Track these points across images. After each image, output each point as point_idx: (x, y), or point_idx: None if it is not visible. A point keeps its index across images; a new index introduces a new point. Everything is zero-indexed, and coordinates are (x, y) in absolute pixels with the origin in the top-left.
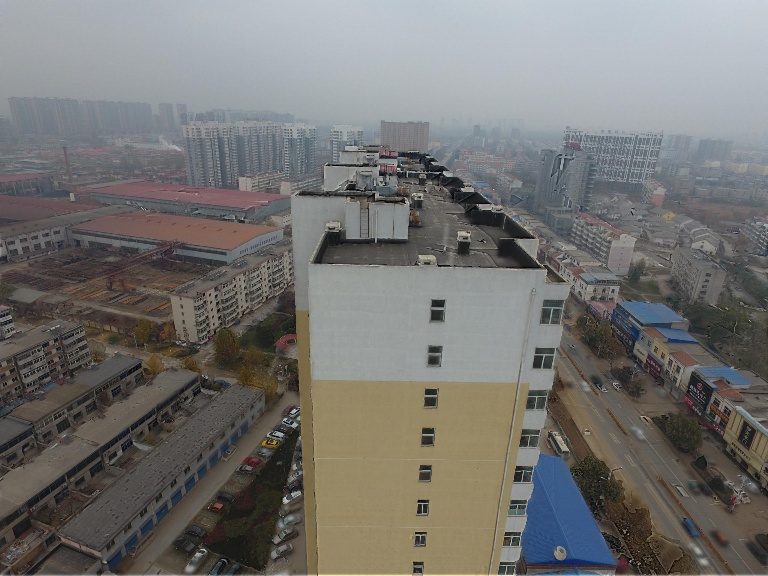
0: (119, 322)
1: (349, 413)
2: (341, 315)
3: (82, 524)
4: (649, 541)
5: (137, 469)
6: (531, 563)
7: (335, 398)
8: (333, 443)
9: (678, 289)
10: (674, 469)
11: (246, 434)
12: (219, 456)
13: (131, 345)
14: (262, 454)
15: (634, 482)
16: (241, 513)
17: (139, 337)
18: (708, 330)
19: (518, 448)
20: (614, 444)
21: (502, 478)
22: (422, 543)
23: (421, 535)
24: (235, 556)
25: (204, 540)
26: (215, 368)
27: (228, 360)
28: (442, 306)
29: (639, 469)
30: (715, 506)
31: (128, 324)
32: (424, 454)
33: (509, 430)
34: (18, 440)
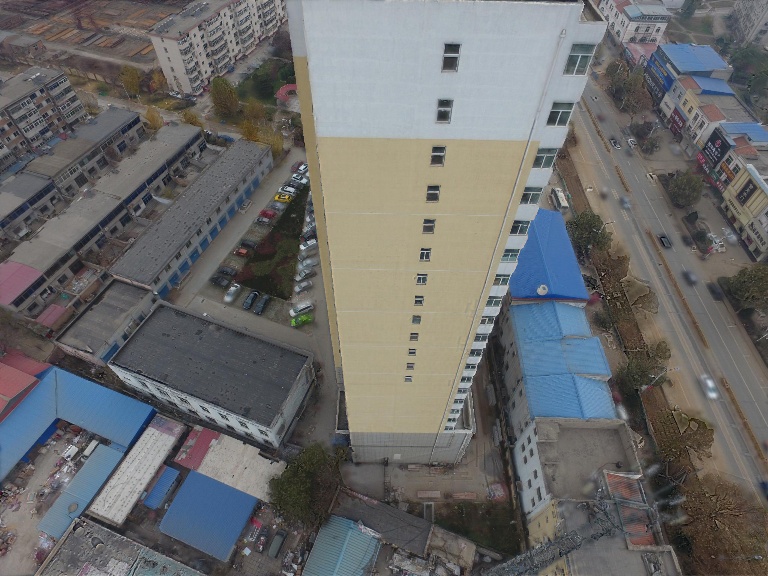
0: (102, 69)
1: (356, 171)
2: (343, 63)
3: (127, 265)
4: (622, 281)
5: (163, 220)
6: (516, 297)
7: (341, 156)
8: (342, 199)
9: (735, 27)
10: (664, 223)
11: (258, 189)
12: (236, 209)
13: (123, 96)
14: (276, 207)
15: (623, 234)
16: (264, 257)
17: (129, 87)
18: (751, 79)
19: (519, 205)
20: (613, 200)
21: (500, 231)
22: (423, 282)
23: (423, 276)
24: (264, 290)
25: (236, 278)
26: (216, 122)
27: (228, 113)
28: (456, 52)
29: (631, 223)
30: (691, 254)
31: (113, 72)
32: (428, 209)
33: (512, 188)
34: (43, 193)
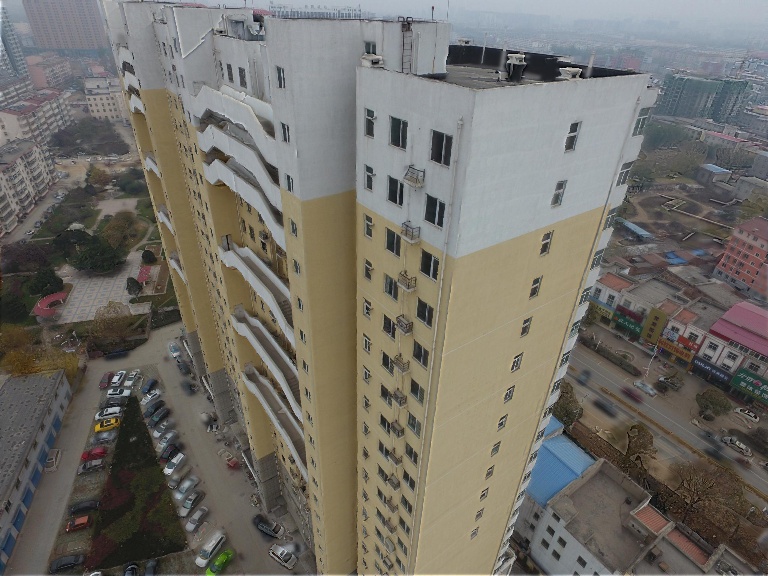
0: None
1: (483, 287)
2: (496, 161)
3: None
4: None
5: None
6: None
7: (473, 274)
8: (461, 330)
9: None
10: None
11: (63, 429)
12: (40, 470)
13: None
14: (103, 440)
15: None
16: (119, 511)
17: None
18: None
19: (589, 272)
20: None
21: (574, 305)
22: (508, 397)
23: (509, 390)
24: (142, 555)
25: (87, 564)
26: None
27: None
28: (575, 131)
29: None
30: None
31: None
32: (529, 307)
33: (588, 256)
34: None
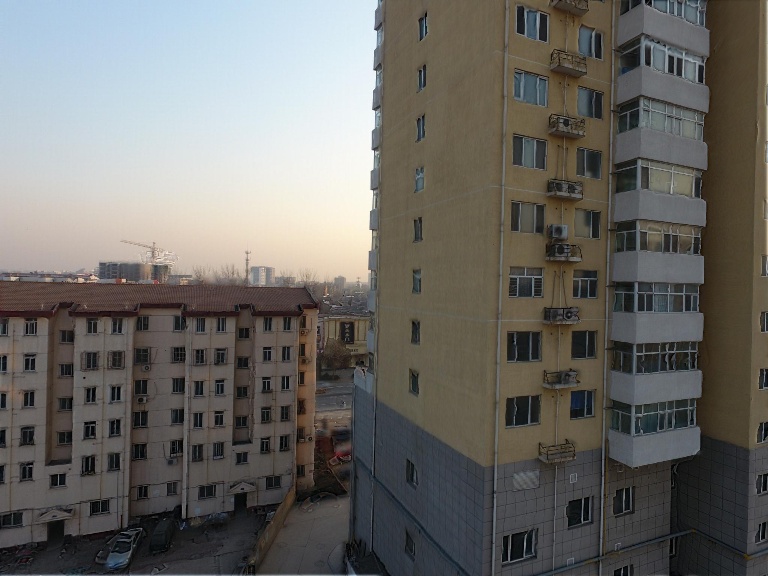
0: None
1: None
2: None
3: None
4: None
5: None
6: None
7: None
8: None
9: None
10: None
11: None
12: None
13: None
14: None
15: None
16: None
17: None
18: None
19: None
20: (350, 397)
21: None
22: None
23: None
24: None
25: None
26: None
27: None
28: None
29: None
30: None
31: None
32: None
33: None
34: None
